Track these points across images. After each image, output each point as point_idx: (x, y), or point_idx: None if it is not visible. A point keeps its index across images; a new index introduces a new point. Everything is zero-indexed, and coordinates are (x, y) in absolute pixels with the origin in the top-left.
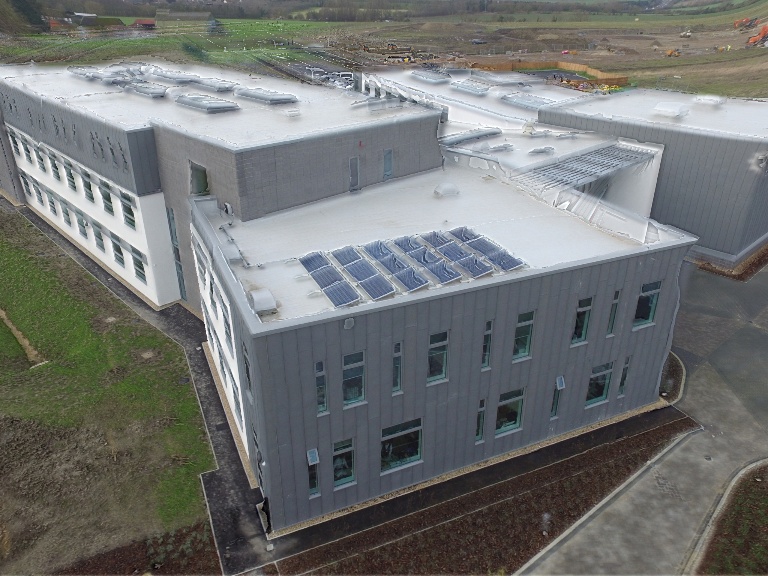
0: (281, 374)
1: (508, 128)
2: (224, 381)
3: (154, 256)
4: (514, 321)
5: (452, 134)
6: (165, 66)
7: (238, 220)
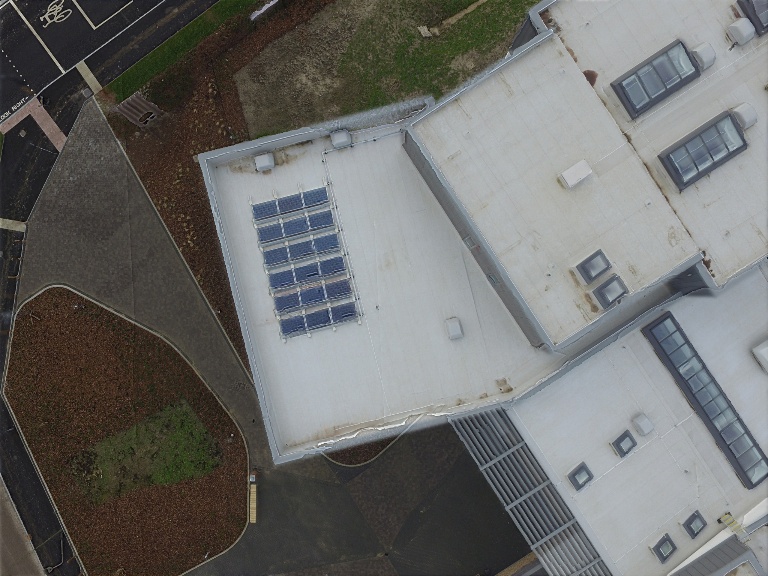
0: None
1: (762, 502)
2: None
3: None
4: None
5: (733, 412)
6: None
7: None
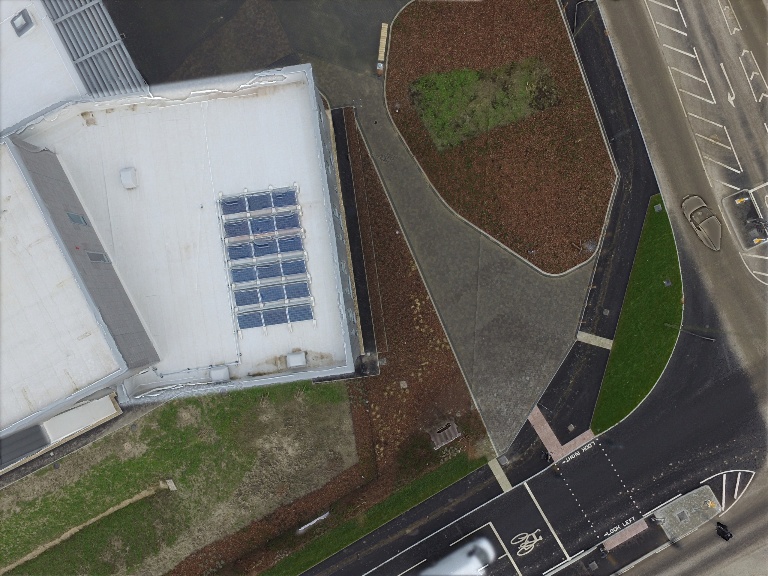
0: None
1: None
2: None
3: (87, 422)
4: None
5: None
6: None
7: None
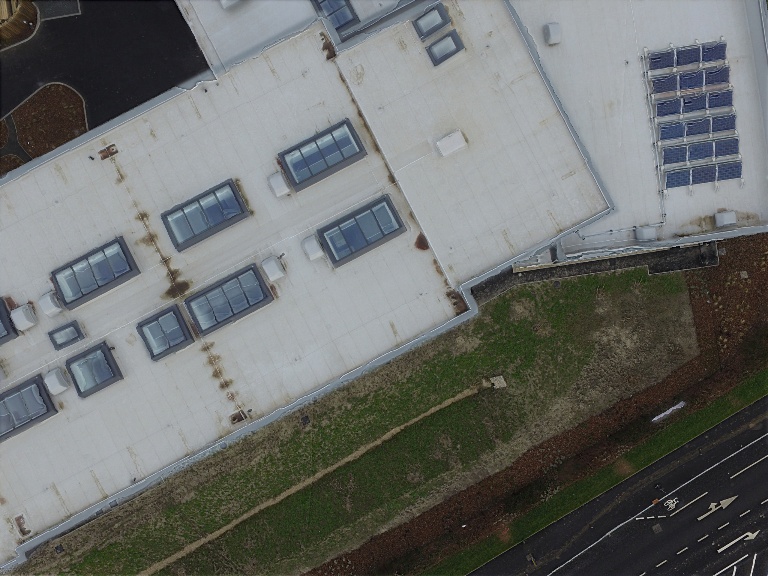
0: None
1: None
2: None
3: None
4: None
5: None
6: None
7: None
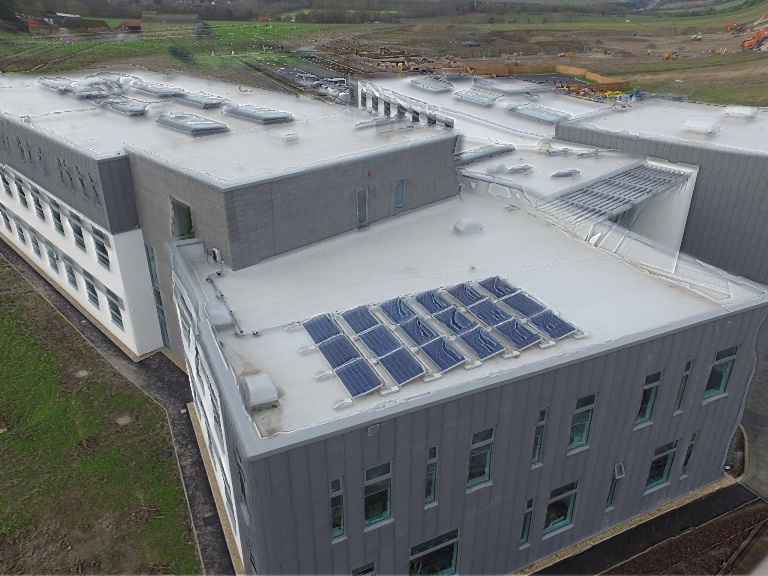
0: (286, 499)
1: (521, 144)
2: (213, 461)
3: (132, 301)
4: (571, 407)
5: (462, 152)
6: (147, 77)
7: (228, 269)
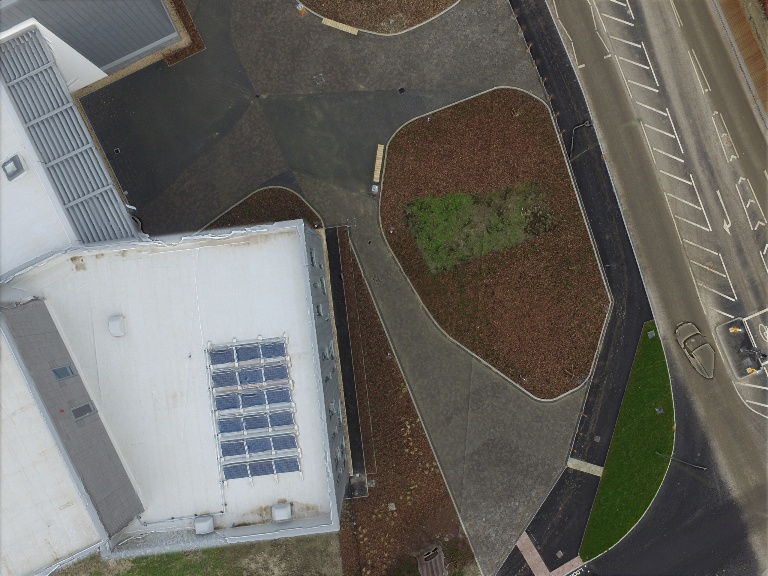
0: (340, 504)
1: None
2: None
3: None
4: None
5: None
6: None
7: None
